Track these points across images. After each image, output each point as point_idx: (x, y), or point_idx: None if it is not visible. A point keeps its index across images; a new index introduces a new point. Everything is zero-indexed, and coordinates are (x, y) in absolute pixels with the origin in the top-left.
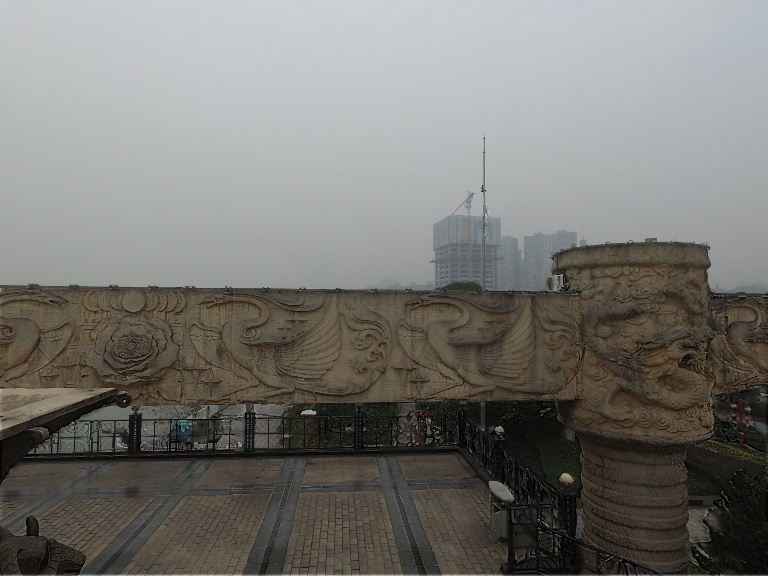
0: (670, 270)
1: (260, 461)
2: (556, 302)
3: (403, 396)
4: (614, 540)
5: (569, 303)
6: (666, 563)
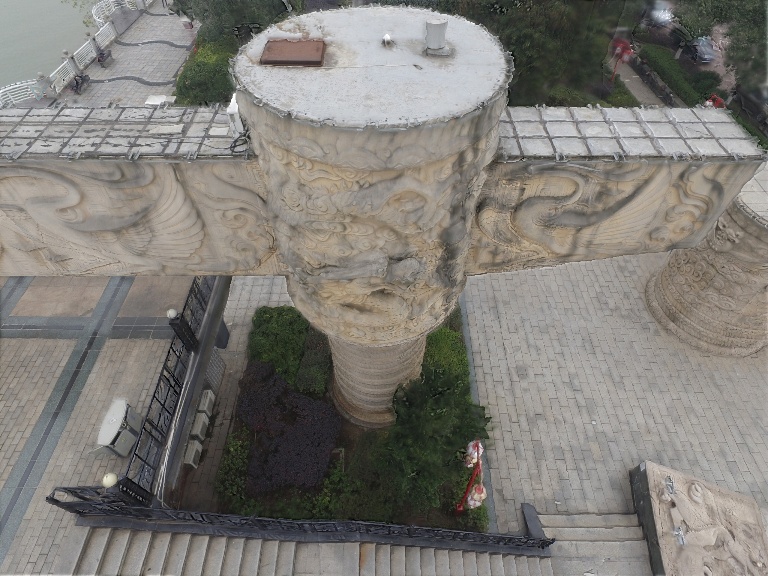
0: (363, 175)
1: None
2: (219, 170)
3: (48, 271)
4: (338, 366)
5: (242, 172)
6: (377, 390)
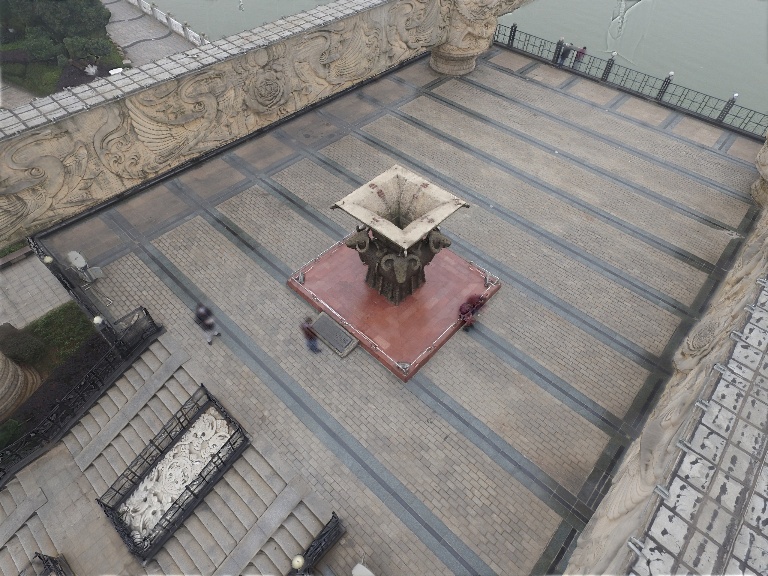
0: None
1: None
2: None
3: None
4: None
5: None
6: None
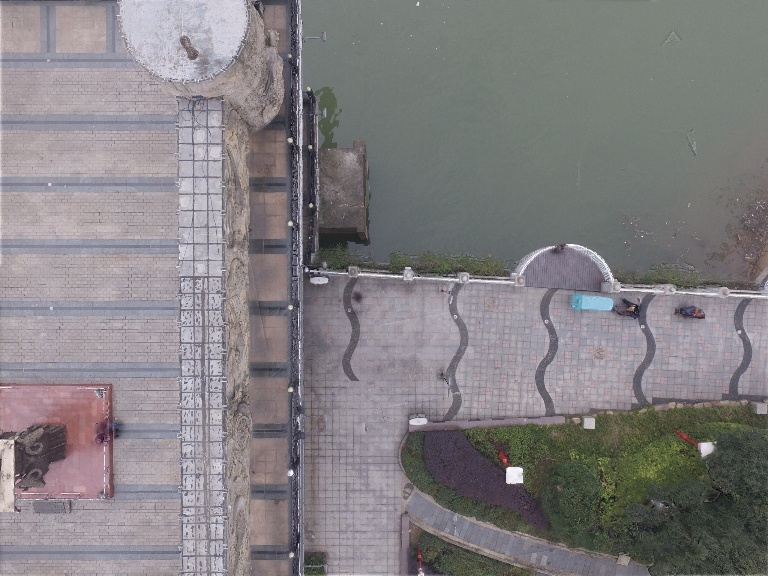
0: None
1: (283, 468)
2: None
3: None
4: None
5: None
6: None
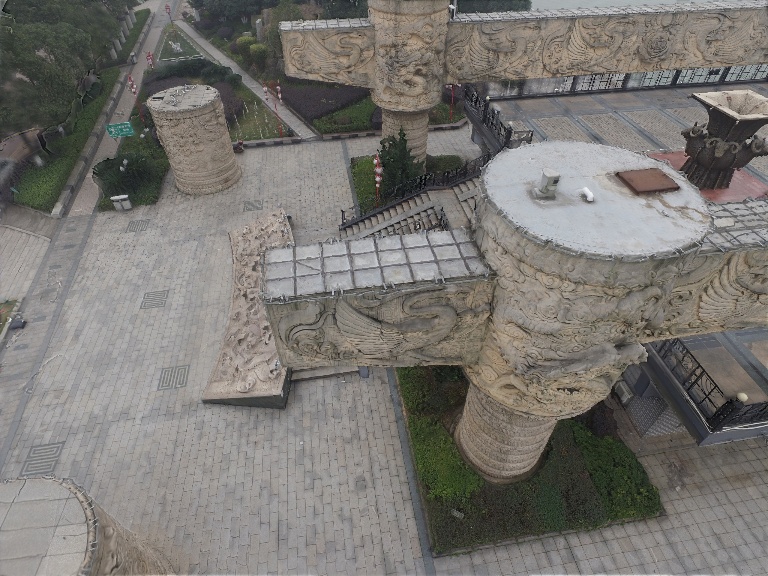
0: None
1: None
2: None
3: None
4: None
5: None
6: None
